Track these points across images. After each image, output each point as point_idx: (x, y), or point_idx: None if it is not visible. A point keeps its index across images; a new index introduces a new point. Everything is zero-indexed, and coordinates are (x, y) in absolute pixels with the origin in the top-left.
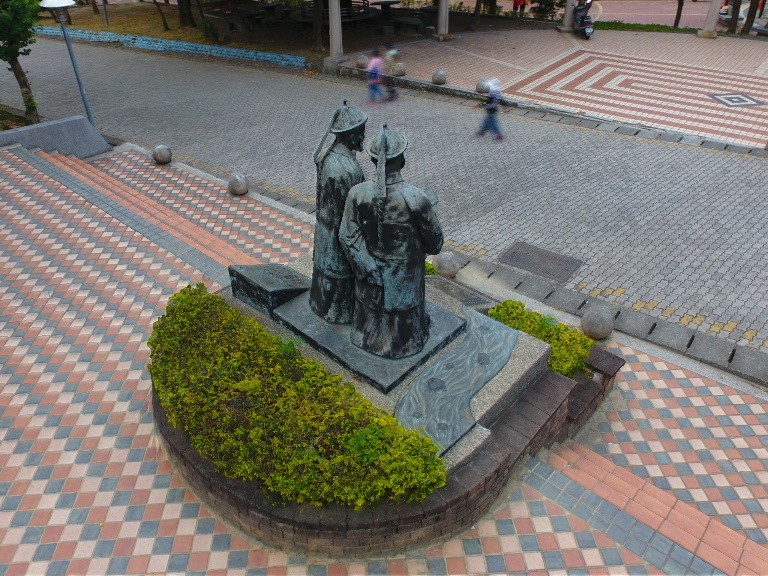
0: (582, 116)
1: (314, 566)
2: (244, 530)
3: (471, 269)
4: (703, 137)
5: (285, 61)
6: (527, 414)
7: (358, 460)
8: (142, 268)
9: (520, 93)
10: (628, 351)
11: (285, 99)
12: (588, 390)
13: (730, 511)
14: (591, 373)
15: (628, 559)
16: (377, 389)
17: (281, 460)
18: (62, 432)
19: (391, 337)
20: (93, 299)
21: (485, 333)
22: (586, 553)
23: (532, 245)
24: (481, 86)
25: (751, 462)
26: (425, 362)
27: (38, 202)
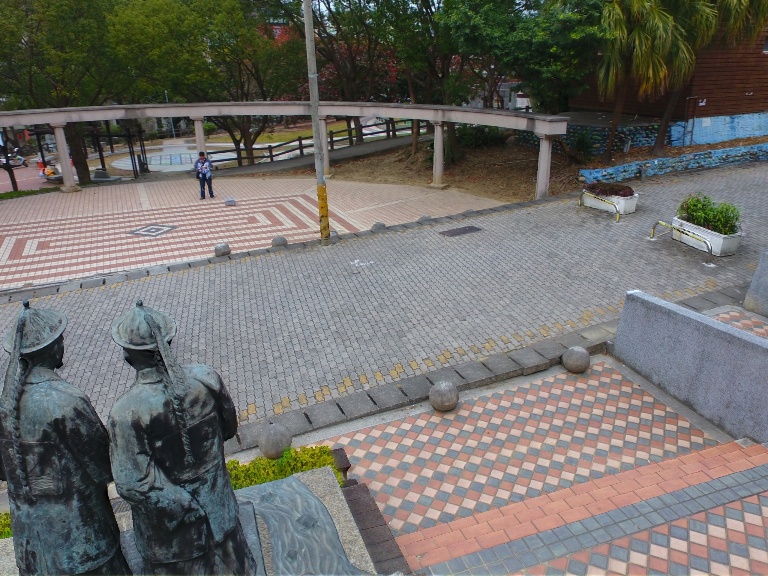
0: (32, 287)
1: None
2: None
3: None
4: (163, 265)
5: None
6: (373, 540)
7: None
8: None
9: None
10: None
11: None
12: None
13: (491, 497)
14: None
15: (539, 573)
16: None
17: None
18: None
19: (232, 574)
20: None
21: (273, 501)
22: None
23: None
24: None
25: (460, 457)
26: (266, 575)
27: None
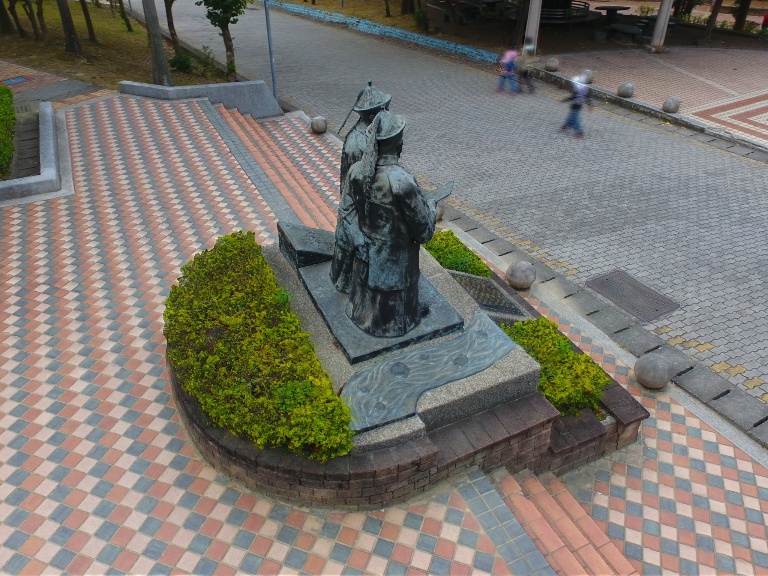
0: None
1: (232, 489)
2: (194, 441)
3: (551, 285)
4: None
5: (480, 56)
6: (487, 426)
7: (276, 406)
8: (241, 215)
9: (714, 118)
10: (678, 410)
11: (461, 92)
12: (588, 429)
13: None
14: (605, 415)
15: None
16: (346, 358)
17: (221, 387)
18: (114, 325)
19: (372, 314)
20: (191, 231)
21: (480, 338)
22: (476, 573)
23: (632, 276)
24: (668, 104)
25: (760, 569)
26: (404, 347)
27: (195, 146)
